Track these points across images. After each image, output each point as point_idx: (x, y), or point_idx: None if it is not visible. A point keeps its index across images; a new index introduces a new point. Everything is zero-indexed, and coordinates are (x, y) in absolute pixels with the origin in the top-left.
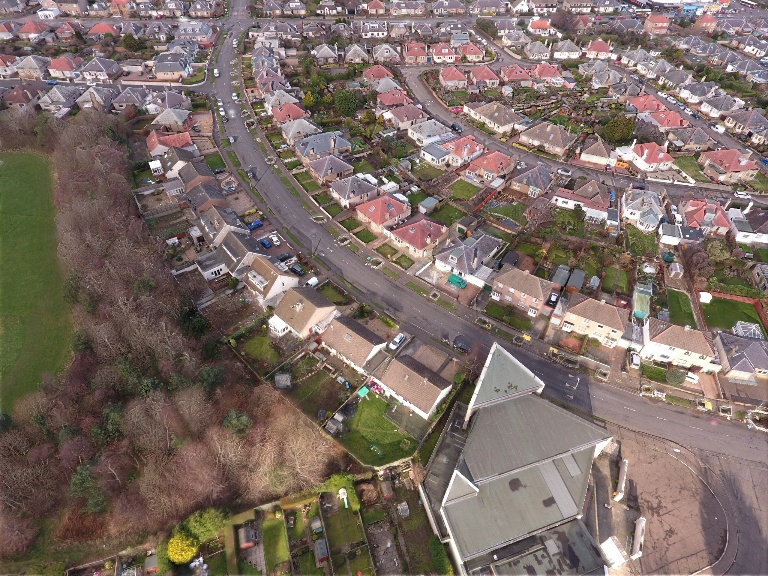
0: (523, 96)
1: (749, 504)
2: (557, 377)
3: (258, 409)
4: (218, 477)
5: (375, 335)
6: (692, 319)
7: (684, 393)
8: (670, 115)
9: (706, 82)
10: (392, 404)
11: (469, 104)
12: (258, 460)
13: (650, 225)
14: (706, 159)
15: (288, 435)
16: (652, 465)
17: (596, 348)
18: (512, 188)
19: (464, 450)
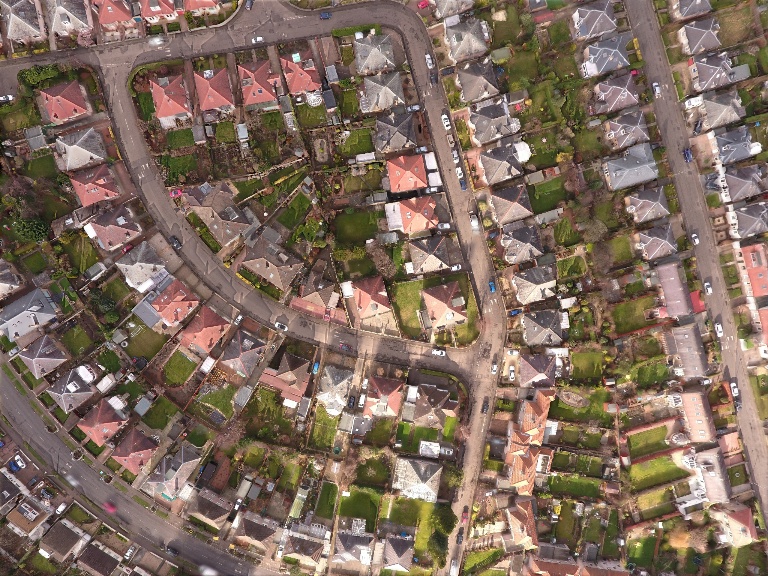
0: (255, 168)
1: None
2: (231, 566)
3: None
4: None
5: (111, 559)
6: (332, 511)
7: (304, 570)
8: (415, 218)
9: (495, 119)
10: None
11: (186, 196)
12: None
13: None
14: None
15: None
16: None
17: None
18: None
19: None
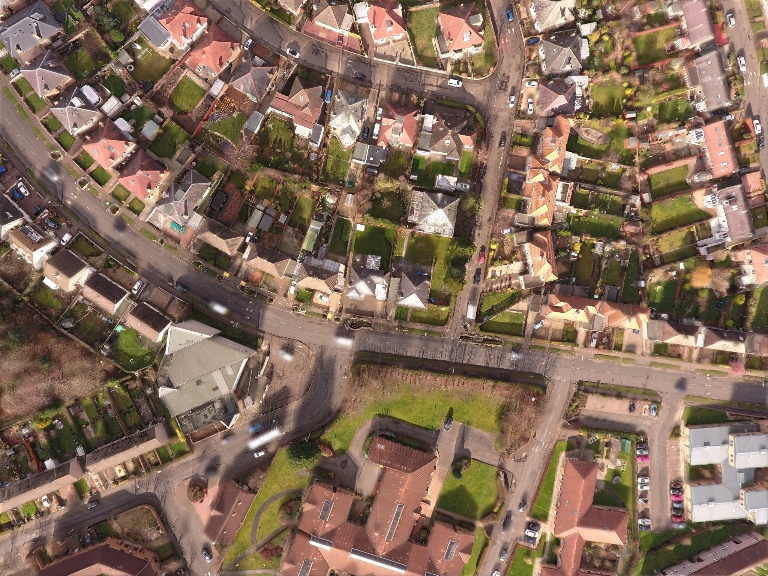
0: None
1: (327, 372)
2: (242, 304)
3: (53, 356)
4: (44, 395)
5: (118, 289)
6: (345, 248)
7: (318, 309)
8: None
9: None
10: (138, 333)
11: None
12: (59, 391)
13: (347, 143)
14: (441, 23)
15: (71, 375)
16: (284, 355)
17: (271, 279)
18: (235, 88)
19: (168, 373)
